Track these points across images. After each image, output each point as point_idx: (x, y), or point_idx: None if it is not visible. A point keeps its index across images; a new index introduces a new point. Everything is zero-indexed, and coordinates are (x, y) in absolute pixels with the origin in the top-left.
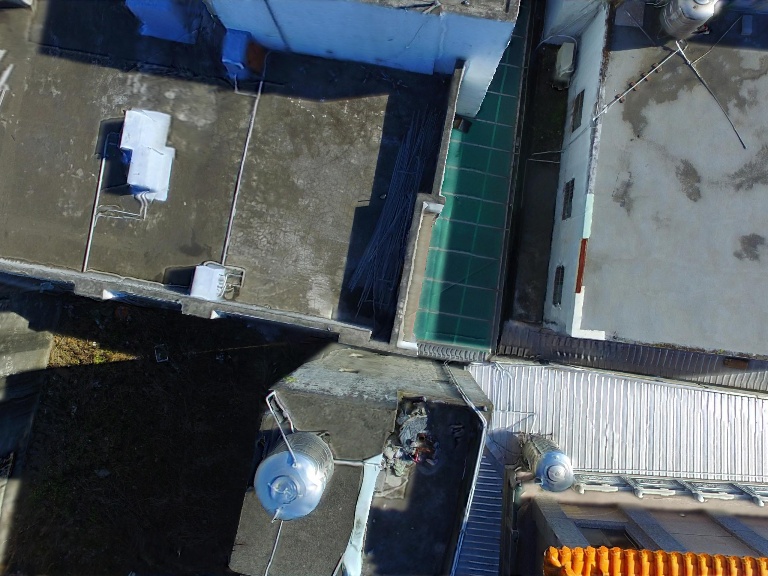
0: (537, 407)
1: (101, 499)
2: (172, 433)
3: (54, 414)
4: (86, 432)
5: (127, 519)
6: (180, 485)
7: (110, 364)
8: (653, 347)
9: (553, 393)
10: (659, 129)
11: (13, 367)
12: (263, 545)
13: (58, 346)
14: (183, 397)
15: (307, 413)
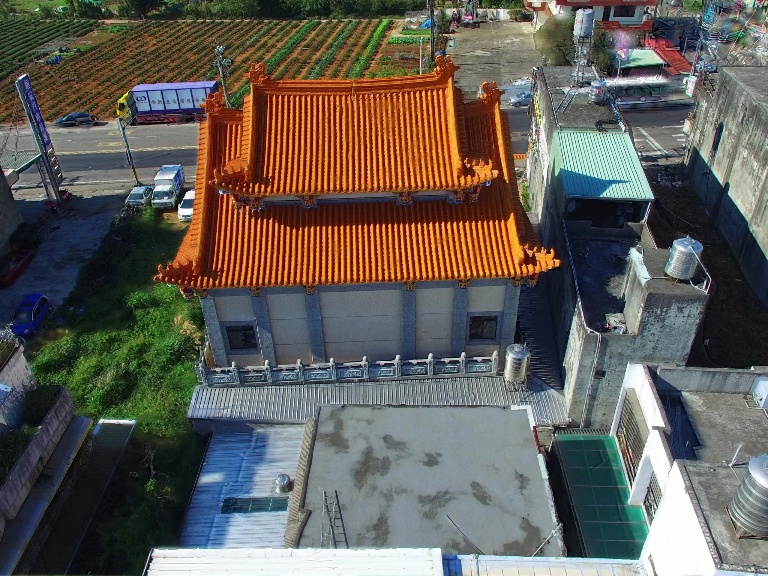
0: None
1: None
2: None
3: None
4: None
5: None
6: None
7: None
8: None
9: None
10: (511, 524)
11: None
12: None
13: None
14: None
15: (687, 290)
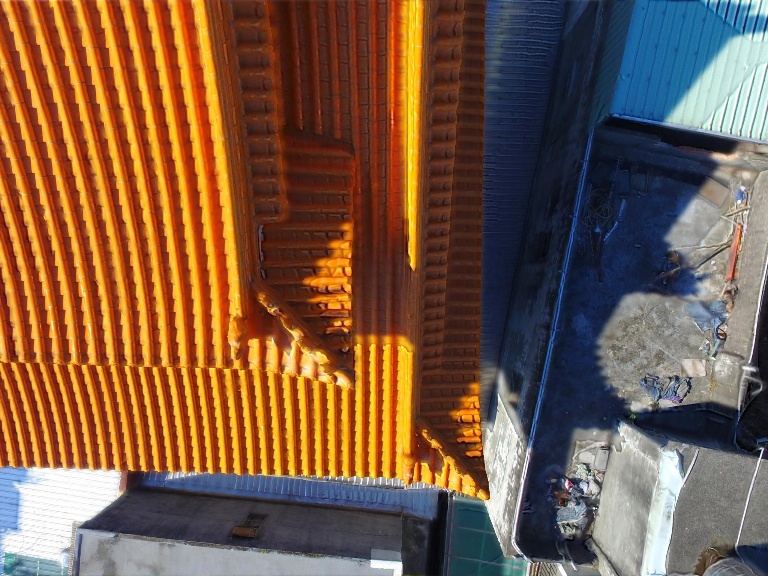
0: None
1: None
2: None
3: None
4: None
5: None
6: None
7: None
8: (320, 543)
9: None
10: None
11: None
12: (763, 492)
13: None
14: None
15: None
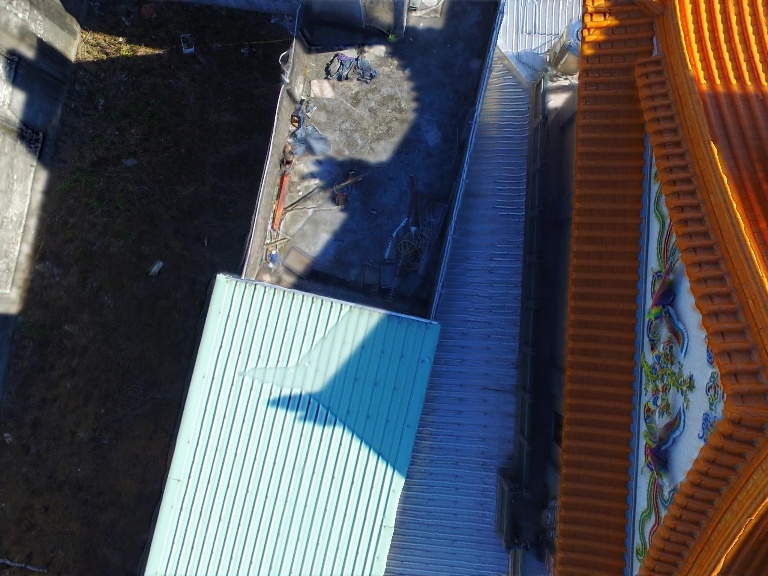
0: (562, 30)
1: (129, 185)
2: (198, 123)
3: (81, 108)
4: (113, 123)
5: (154, 208)
6: (206, 174)
7: (137, 57)
8: None
9: (578, 16)
10: None
11: (43, 32)
12: None
13: (85, 41)
14: (209, 88)
15: None
